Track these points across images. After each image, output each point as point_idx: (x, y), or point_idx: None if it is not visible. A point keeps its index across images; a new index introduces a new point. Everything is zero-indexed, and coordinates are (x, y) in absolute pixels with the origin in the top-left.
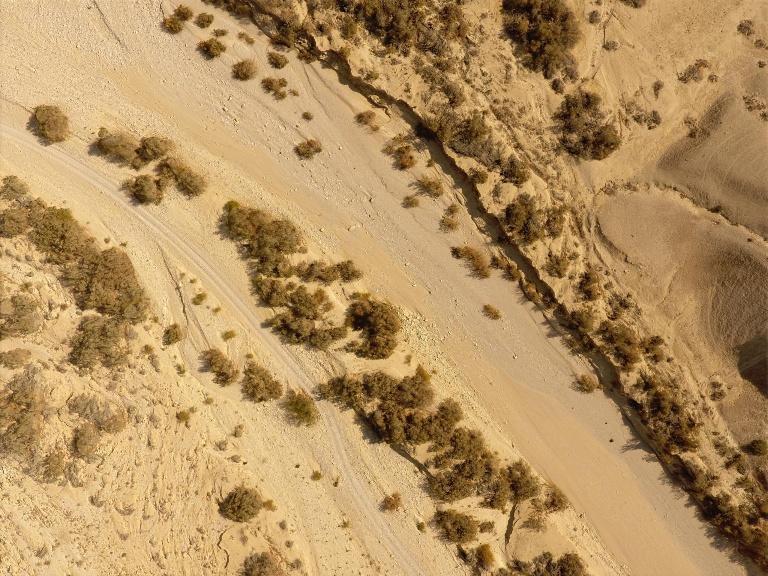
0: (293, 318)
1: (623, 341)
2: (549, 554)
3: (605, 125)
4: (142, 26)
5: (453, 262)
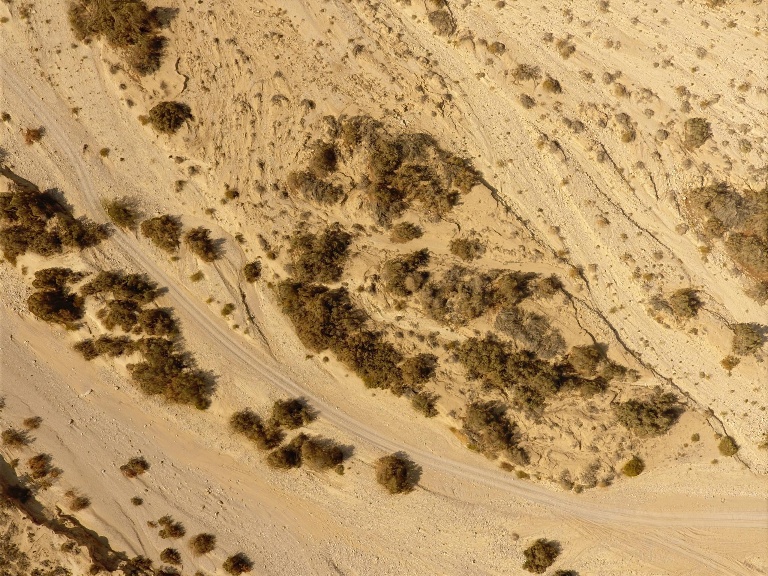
0: None
1: None
2: None
3: None
4: None
5: None
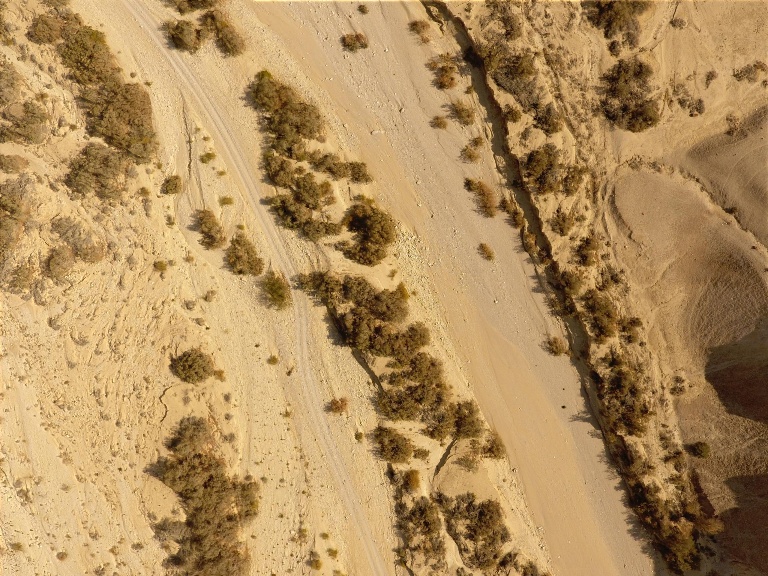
0: (293, 201)
1: (604, 312)
2: (473, 495)
3: (649, 100)
4: None
5: (463, 193)
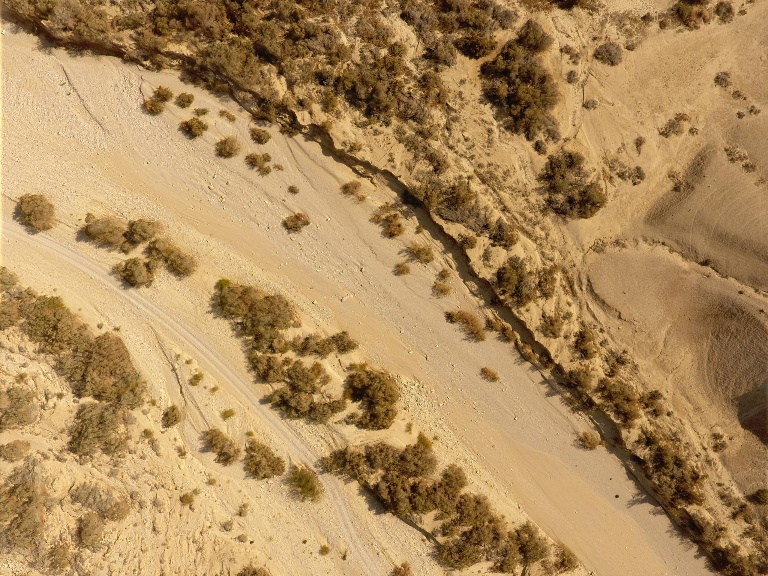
0: (291, 394)
1: (622, 398)
2: None
3: (590, 183)
4: (123, 109)
5: (448, 327)
